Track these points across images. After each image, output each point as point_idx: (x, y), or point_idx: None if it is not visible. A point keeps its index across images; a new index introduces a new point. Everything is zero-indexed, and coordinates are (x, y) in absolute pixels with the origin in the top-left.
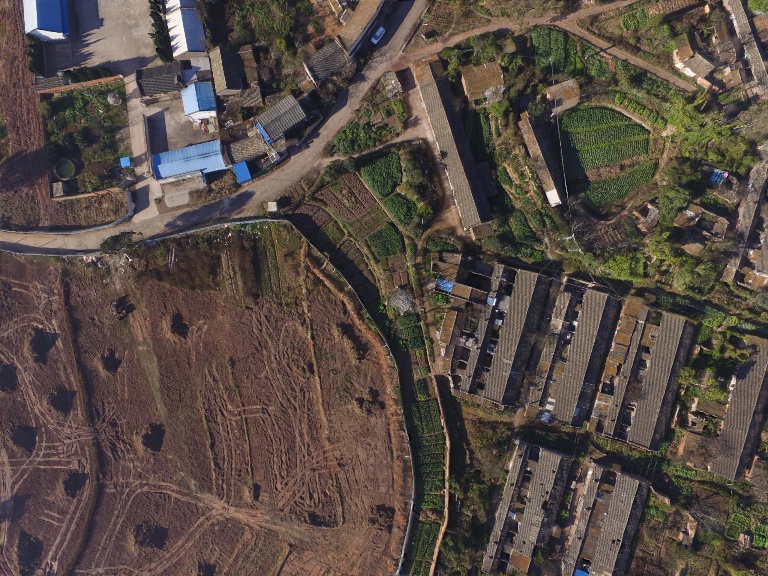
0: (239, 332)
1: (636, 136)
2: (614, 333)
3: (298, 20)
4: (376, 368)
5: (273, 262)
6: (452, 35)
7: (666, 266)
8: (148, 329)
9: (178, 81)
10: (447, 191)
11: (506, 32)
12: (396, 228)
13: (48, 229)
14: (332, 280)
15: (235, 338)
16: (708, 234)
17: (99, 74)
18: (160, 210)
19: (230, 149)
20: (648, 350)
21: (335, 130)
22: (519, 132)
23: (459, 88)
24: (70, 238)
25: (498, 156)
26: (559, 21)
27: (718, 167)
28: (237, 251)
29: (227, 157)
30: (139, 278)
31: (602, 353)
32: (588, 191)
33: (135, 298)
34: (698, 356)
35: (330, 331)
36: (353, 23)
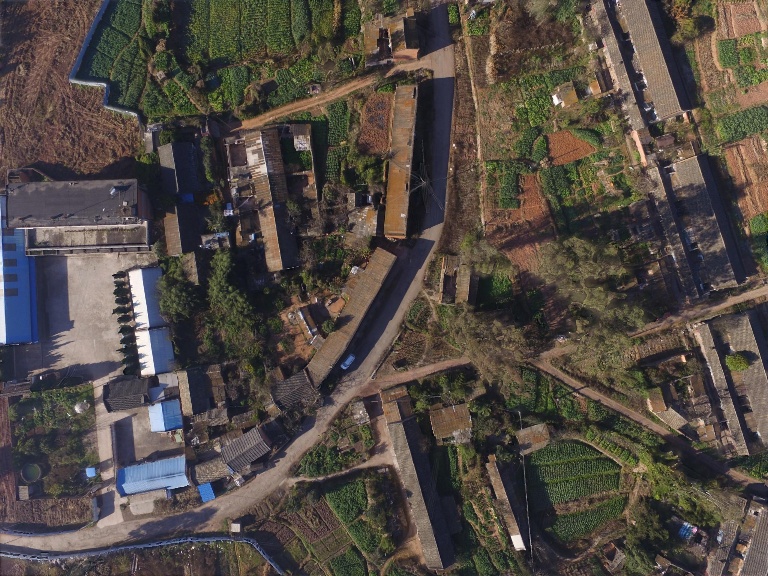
0: None
1: (607, 470)
2: None
3: (267, 346)
4: None
5: None
6: (423, 366)
7: None
8: None
9: (145, 402)
10: (412, 519)
11: None
12: (359, 553)
13: (14, 526)
14: None
15: None
16: None
17: None
18: (125, 517)
19: (195, 472)
20: None
21: (302, 451)
22: (486, 474)
23: (428, 420)
24: (35, 537)
25: (464, 493)
26: (532, 358)
27: (687, 520)
28: (199, 568)
29: (191, 481)
30: None
31: None
32: (555, 526)
33: None
34: None
35: None
36: (322, 356)
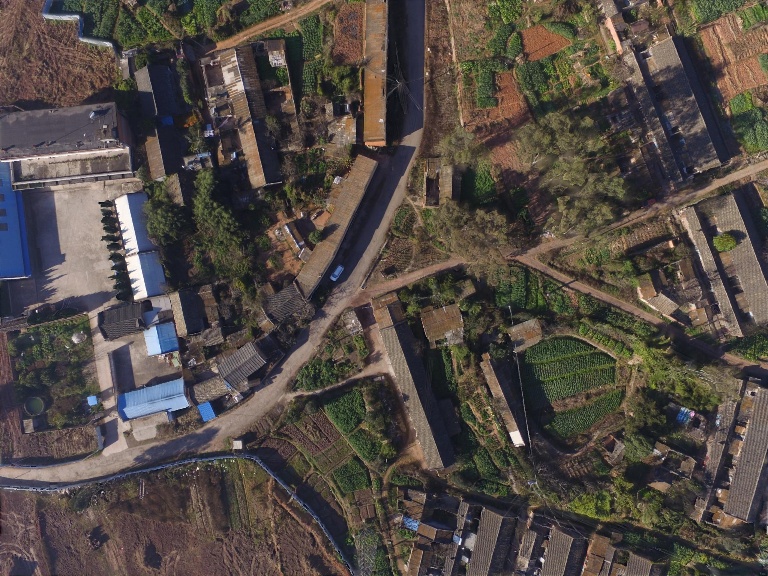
0: (211, 563)
1: (602, 365)
2: (581, 569)
3: (256, 262)
4: None
5: (241, 495)
6: (411, 272)
7: None
8: (123, 558)
9: (139, 326)
10: (411, 425)
11: (466, 268)
12: (361, 462)
13: (22, 461)
14: (300, 514)
15: (207, 569)
16: (675, 473)
17: (62, 316)
18: (129, 444)
19: (193, 392)
20: None
21: (297, 365)
22: (481, 373)
23: (420, 325)
24: (43, 470)
25: (461, 394)
26: (520, 256)
27: (684, 405)
28: (205, 488)
29: (191, 400)
30: (111, 510)
31: None
32: (553, 422)
33: (109, 528)
34: None
35: (299, 562)
36: (310, 267)
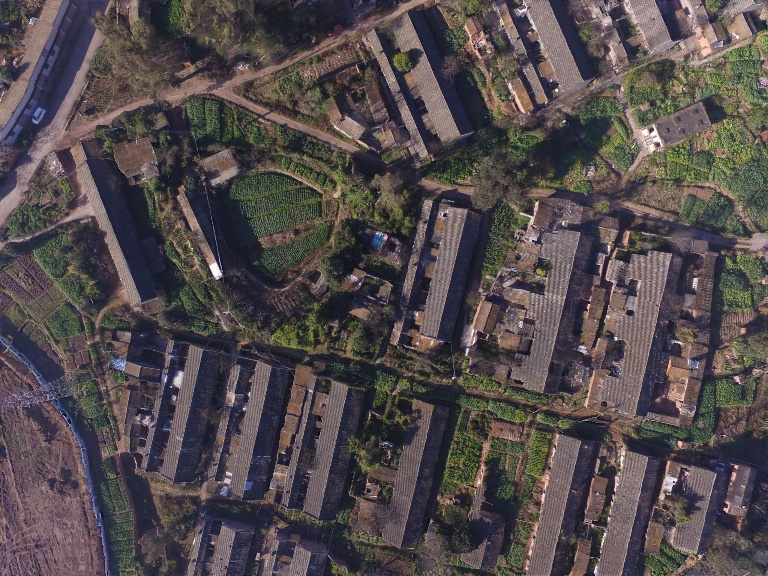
0: None
1: (308, 199)
2: None
3: None
4: (67, 448)
5: None
6: (111, 111)
7: (333, 333)
8: None
9: None
10: None
11: (163, 104)
12: (74, 308)
13: None
14: (15, 363)
15: None
16: (372, 298)
17: None
18: None
19: None
20: (320, 419)
21: (7, 213)
22: (178, 206)
23: None
24: None
25: None
26: (215, 90)
27: (379, 229)
28: None
29: None
30: None
31: (275, 424)
32: (262, 259)
33: None
34: (370, 422)
35: (18, 414)
36: (5, 107)
